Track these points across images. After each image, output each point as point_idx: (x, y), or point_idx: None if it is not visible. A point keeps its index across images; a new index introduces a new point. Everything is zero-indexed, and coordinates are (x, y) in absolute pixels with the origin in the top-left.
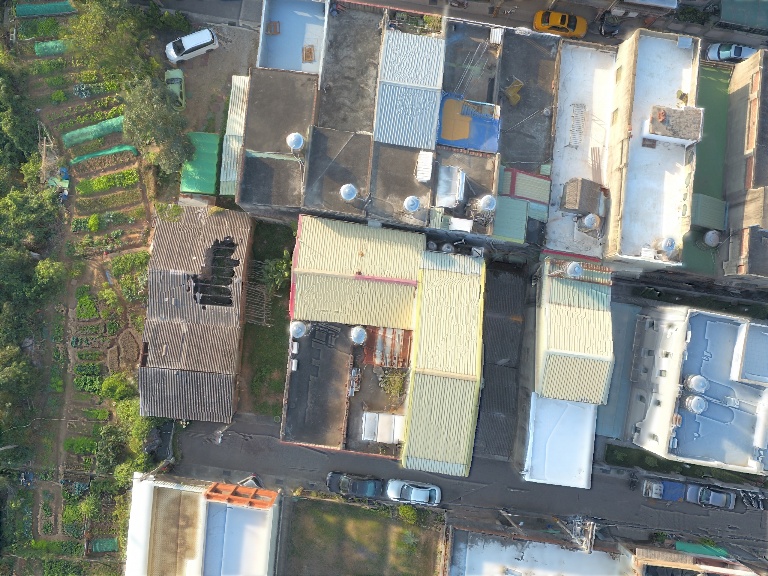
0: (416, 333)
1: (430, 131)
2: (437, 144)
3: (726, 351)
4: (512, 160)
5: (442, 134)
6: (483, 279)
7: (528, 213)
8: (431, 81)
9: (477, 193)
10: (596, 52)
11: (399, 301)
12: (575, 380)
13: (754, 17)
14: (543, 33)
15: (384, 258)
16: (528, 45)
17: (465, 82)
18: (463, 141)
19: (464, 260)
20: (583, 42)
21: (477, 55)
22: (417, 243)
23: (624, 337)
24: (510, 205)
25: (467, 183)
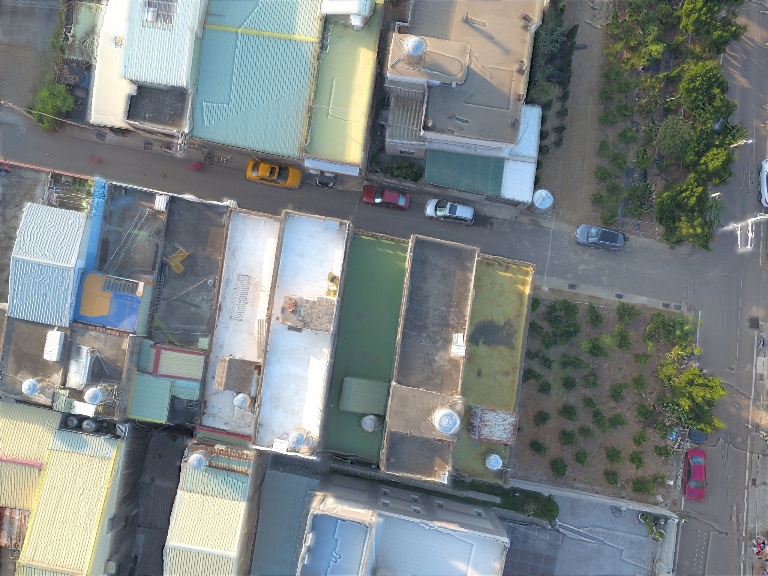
0: (29, 521)
1: (64, 309)
2: (73, 321)
3: (355, 553)
4: (175, 330)
5: (81, 310)
6: (112, 463)
7: (171, 392)
8: (65, 258)
9: (111, 373)
10: (269, 220)
11: (24, 482)
12: (198, 575)
13: (459, 179)
14: (210, 202)
15: (5, 440)
16: (200, 211)
17: (132, 248)
18: (102, 318)
19: (96, 441)
20: (251, 212)
21: (146, 220)
22: (44, 424)
23: (298, 512)
24: (151, 384)
25: (101, 363)
